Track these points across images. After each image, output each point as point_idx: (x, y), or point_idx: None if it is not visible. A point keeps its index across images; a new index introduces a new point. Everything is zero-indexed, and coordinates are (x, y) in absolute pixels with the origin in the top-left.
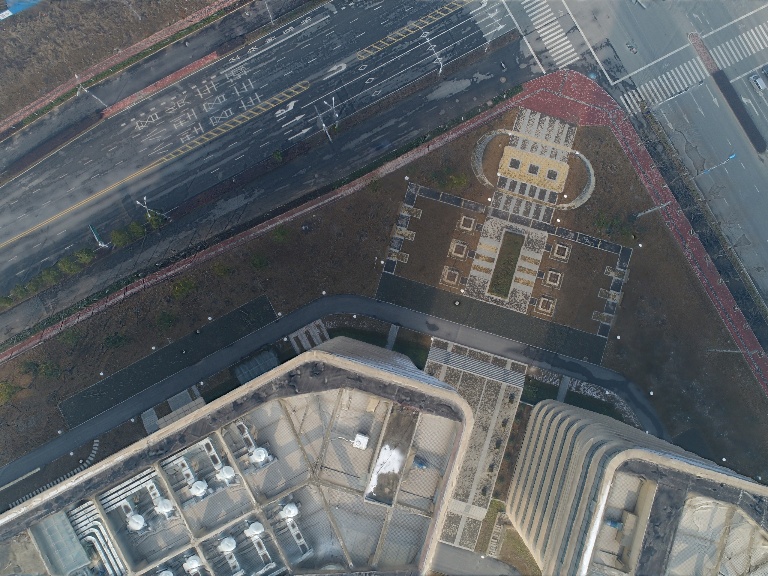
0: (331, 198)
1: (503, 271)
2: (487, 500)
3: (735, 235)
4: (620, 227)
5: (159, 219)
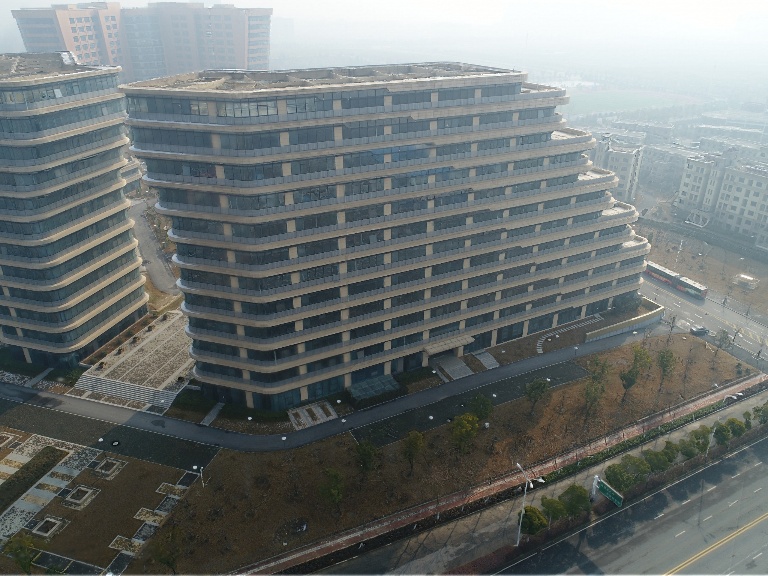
0: (253, 572)
1: (32, 470)
2: None
3: None
4: None
5: (521, 512)
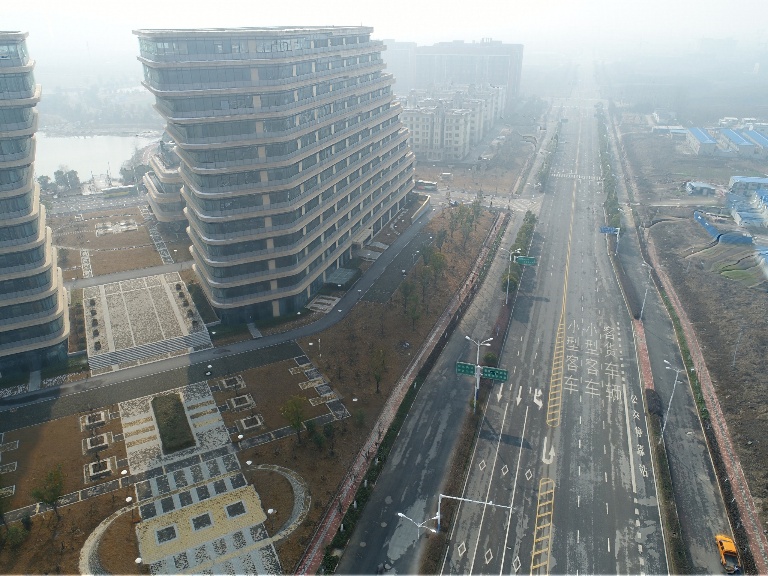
0: (411, 372)
1: (173, 411)
2: None
3: None
4: (5, 543)
5: (505, 281)
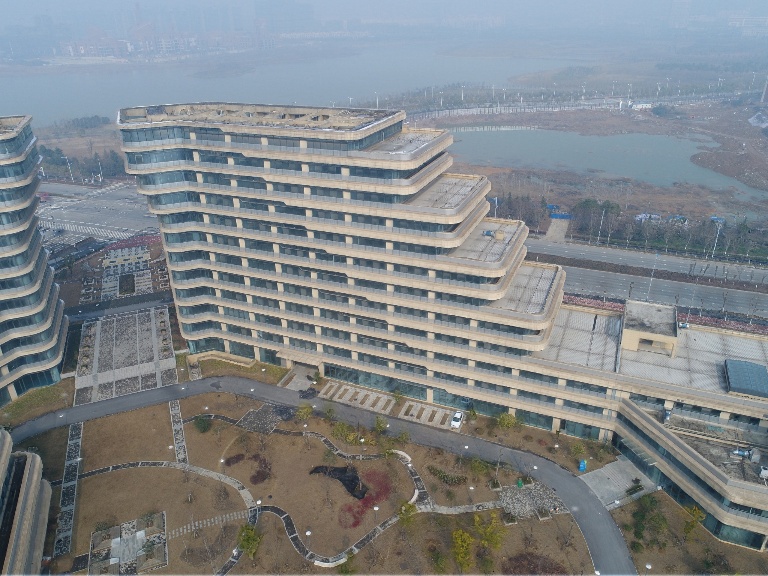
0: None
1: None
2: (171, 354)
3: None
4: None
5: None
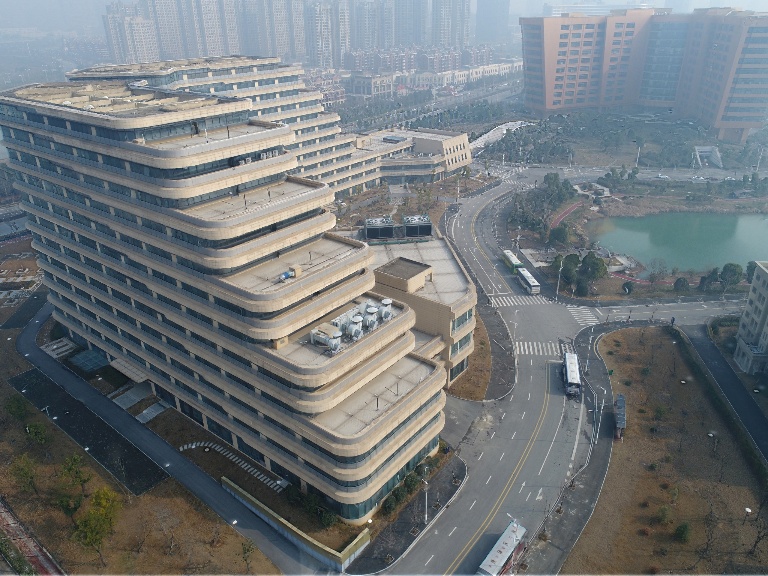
0: None
1: (11, 285)
2: None
3: (5, 234)
4: None
5: None
